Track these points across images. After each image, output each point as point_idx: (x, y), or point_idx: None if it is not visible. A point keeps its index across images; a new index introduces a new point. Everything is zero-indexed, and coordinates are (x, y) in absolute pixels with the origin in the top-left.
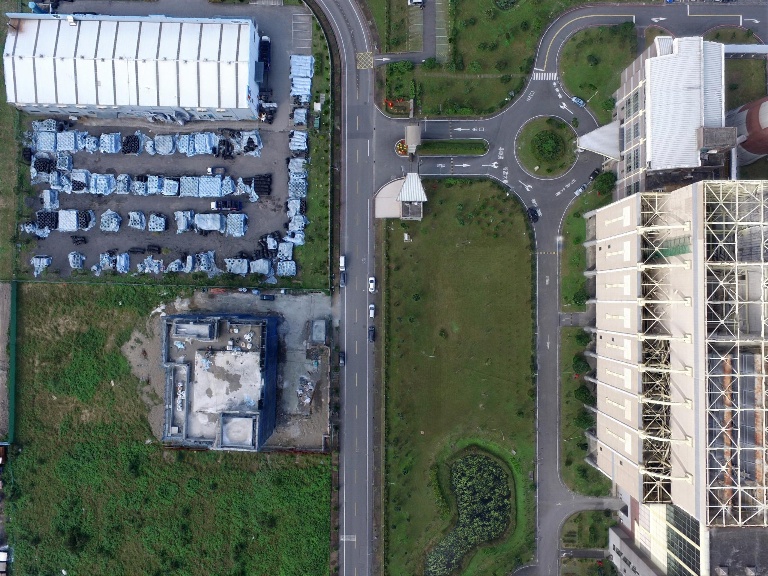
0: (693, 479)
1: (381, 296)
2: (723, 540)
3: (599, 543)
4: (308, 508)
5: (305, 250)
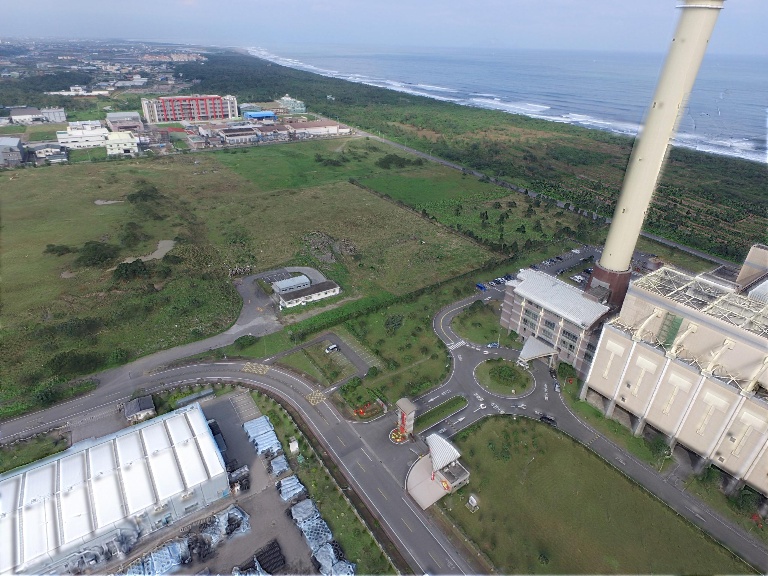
0: None
1: None
2: None
3: None
4: None
5: None
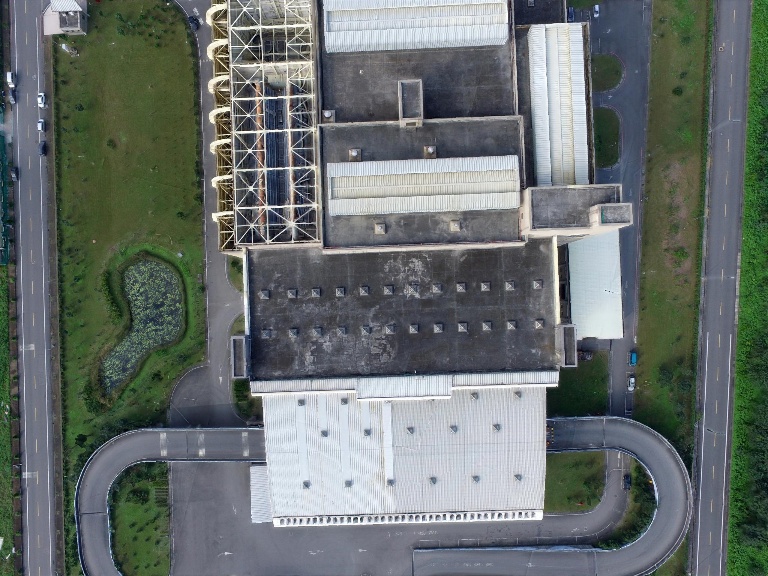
0: None
1: (51, 111)
2: (265, 265)
3: None
4: None
5: None
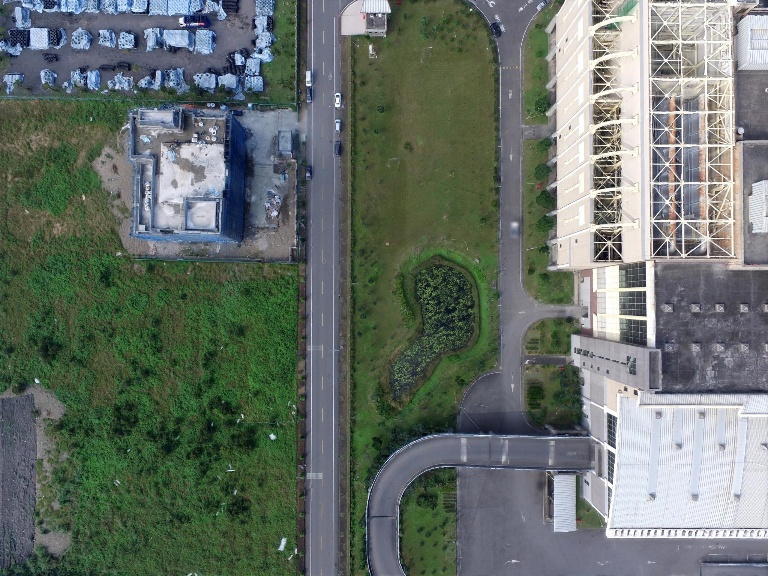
0: (639, 222)
1: (347, 112)
2: (668, 278)
3: (561, 349)
4: (275, 318)
5: (272, 67)
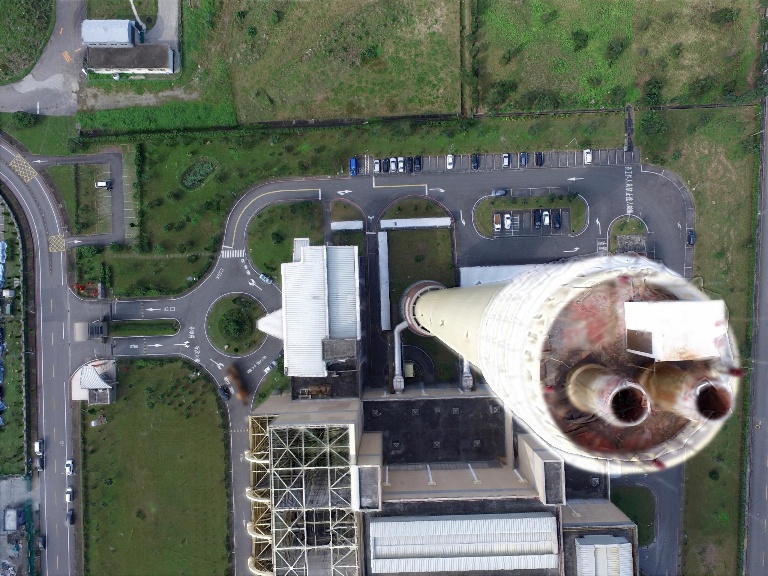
0: None
1: (79, 478)
2: None
3: None
4: None
5: (3, 435)
